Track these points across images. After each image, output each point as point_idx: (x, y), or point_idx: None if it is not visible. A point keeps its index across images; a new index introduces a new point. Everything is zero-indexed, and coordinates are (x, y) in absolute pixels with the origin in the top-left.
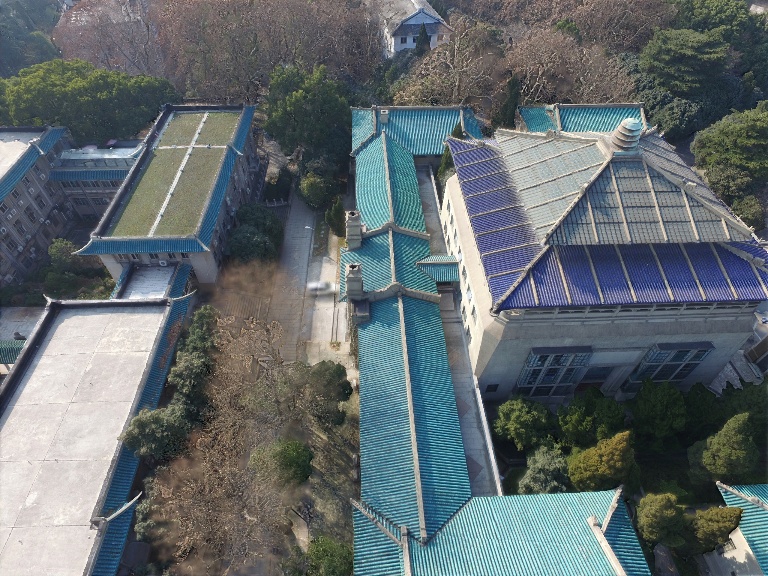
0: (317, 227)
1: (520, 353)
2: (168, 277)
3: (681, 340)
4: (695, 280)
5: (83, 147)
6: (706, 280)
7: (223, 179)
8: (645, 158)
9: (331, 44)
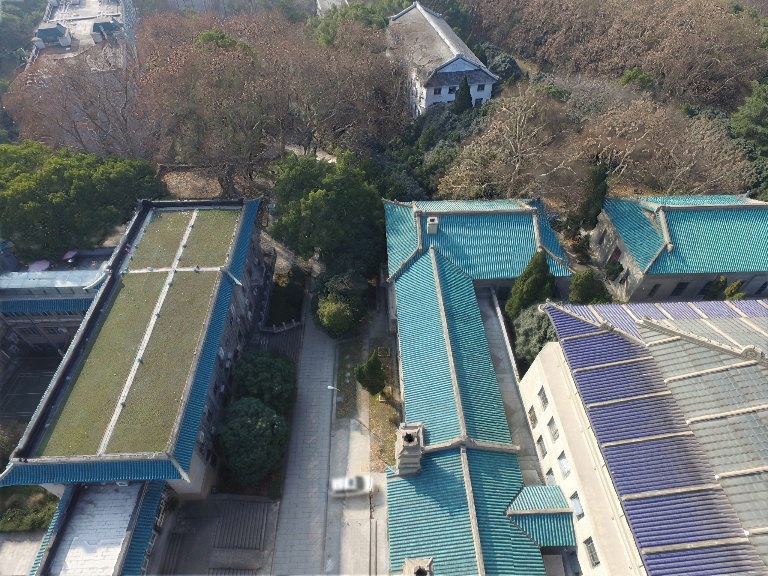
0: (340, 365)
1: None
2: (129, 507)
3: None
4: None
5: (30, 264)
6: None
7: (214, 331)
8: None
9: None
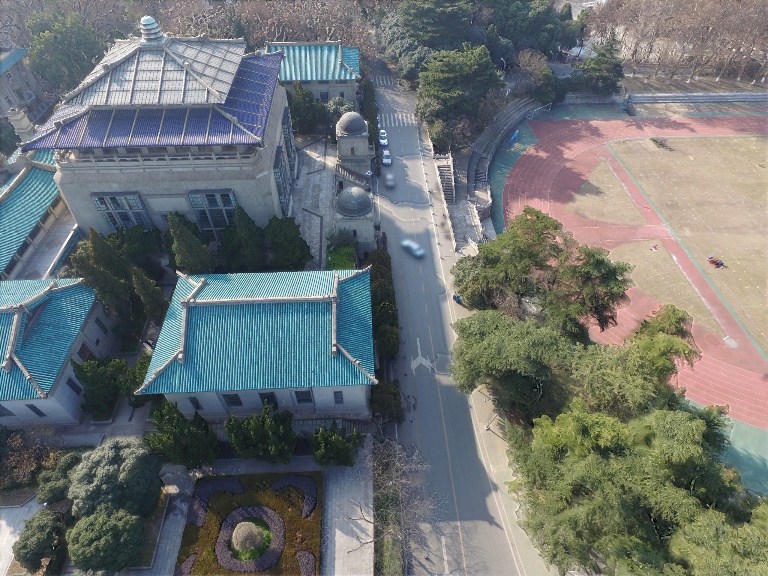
0: None
1: (88, 198)
2: None
3: (206, 187)
4: (182, 132)
5: None
6: (191, 132)
7: None
8: (164, 47)
9: (148, 7)
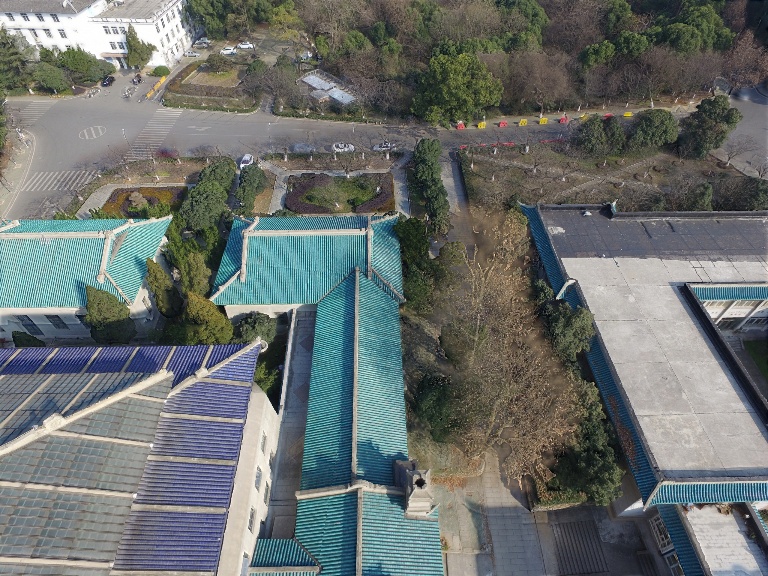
0: None
1: None
2: None
3: None
4: (6, 366)
5: None
6: None
7: None
8: None
9: None
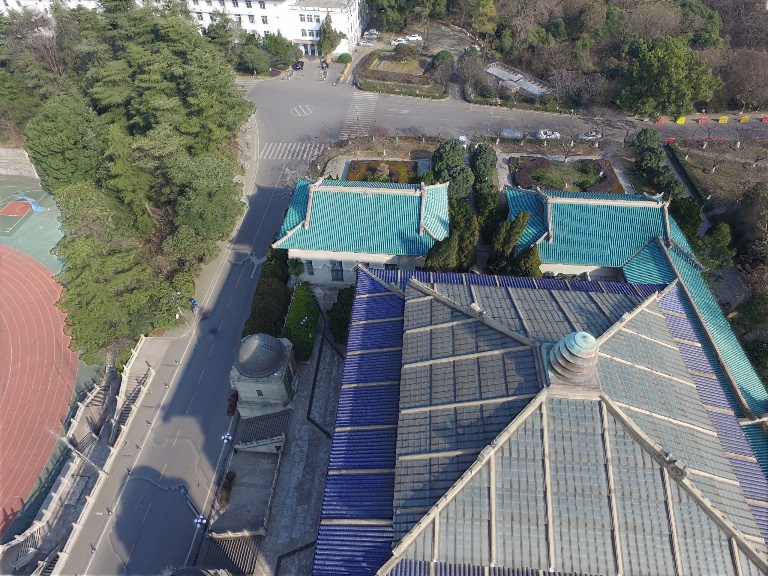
0: None
1: None
2: None
3: None
4: None
5: None
6: None
7: None
8: (536, 342)
9: None
